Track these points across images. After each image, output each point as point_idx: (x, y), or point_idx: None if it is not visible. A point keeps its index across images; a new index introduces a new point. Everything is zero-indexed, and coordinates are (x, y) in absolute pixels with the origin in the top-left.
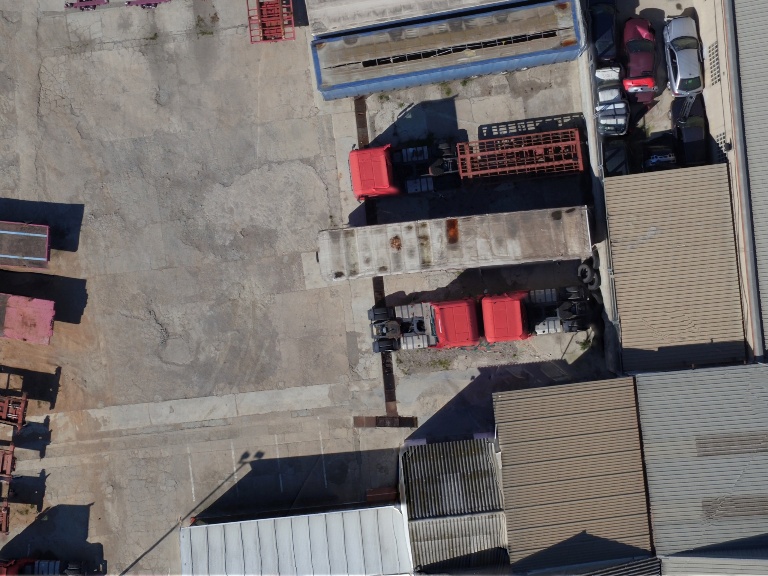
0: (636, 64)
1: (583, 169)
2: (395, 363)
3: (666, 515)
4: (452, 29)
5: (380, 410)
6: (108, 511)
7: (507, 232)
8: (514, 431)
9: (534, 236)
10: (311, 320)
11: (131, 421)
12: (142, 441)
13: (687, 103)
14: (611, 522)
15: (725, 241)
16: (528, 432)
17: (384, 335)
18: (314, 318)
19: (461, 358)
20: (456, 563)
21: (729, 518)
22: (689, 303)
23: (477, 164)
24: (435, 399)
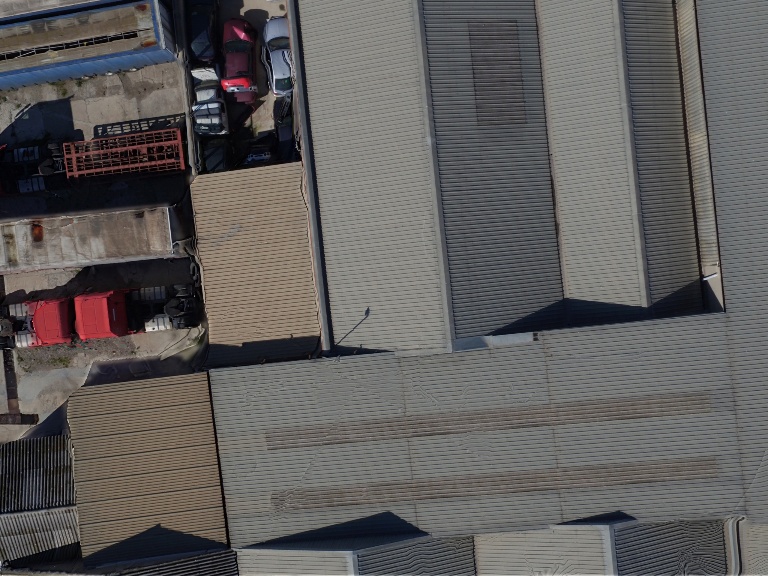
0: (232, 65)
1: (185, 168)
2: (16, 361)
3: (240, 508)
4: (35, 30)
5: (2, 408)
6: None
7: (90, 230)
8: (86, 426)
9: (117, 234)
10: None
11: None
12: None
13: (286, 103)
14: (186, 515)
15: (303, 238)
16: (101, 427)
17: None
18: None
19: (80, 355)
20: (40, 558)
21: (300, 510)
22: (271, 299)
23: (83, 164)
24: (55, 396)
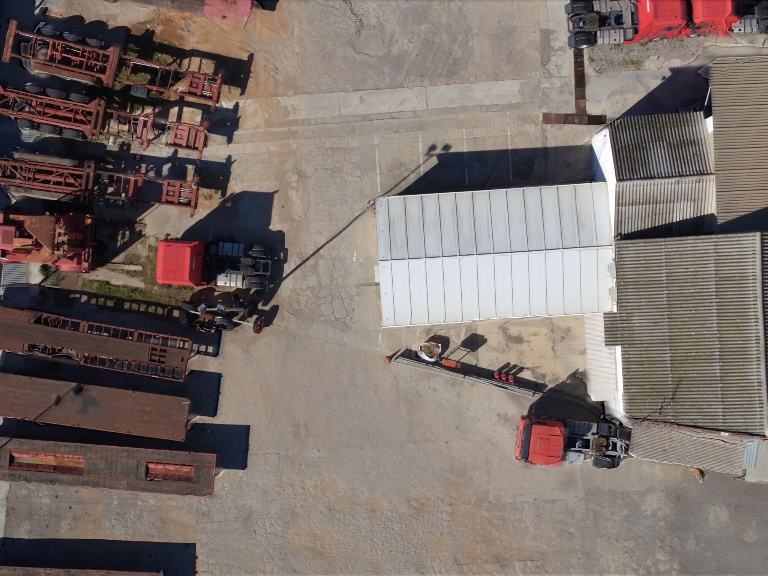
0: None
1: None
2: (587, 61)
3: None
4: None
5: (570, 107)
6: (292, 199)
7: None
8: (727, 94)
9: None
10: (506, 16)
11: (320, 110)
12: (330, 130)
13: None
14: None
15: None
16: (740, 97)
17: (581, 28)
18: (509, 14)
19: (653, 59)
20: (658, 230)
21: None
22: None
23: None
24: (625, 98)
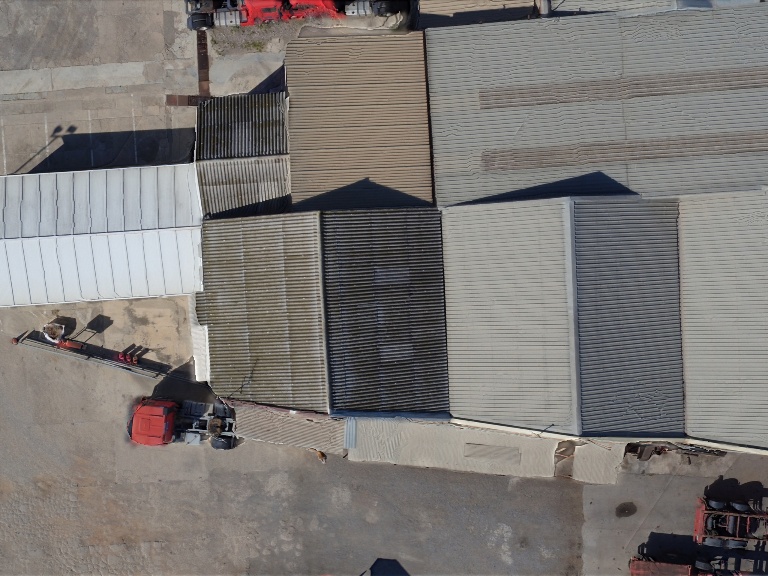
0: None
1: None
2: (210, 43)
3: (448, 167)
4: None
5: (193, 89)
6: None
7: None
8: (303, 74)
9: None
10: None
11: None
12: None
13: None
14: (394, 172)
15: None
16: (317, 77)
17: (197, 10)
18: None
19: (274, 41)
20: (244, 210)
21: (508, 171)
22: None
23: None
24: (247, 80)
